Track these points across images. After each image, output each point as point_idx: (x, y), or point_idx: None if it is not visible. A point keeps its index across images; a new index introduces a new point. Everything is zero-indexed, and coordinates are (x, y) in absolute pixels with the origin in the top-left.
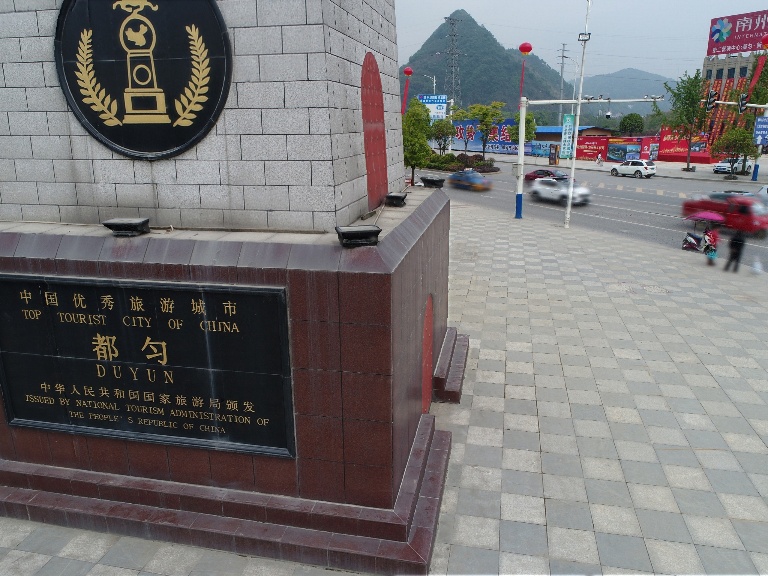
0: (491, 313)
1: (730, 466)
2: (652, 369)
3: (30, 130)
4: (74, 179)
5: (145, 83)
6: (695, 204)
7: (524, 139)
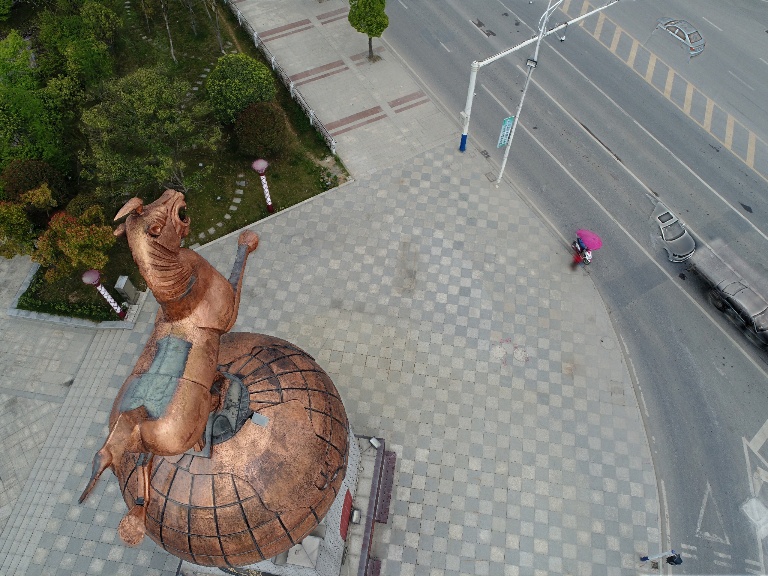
0: (413, 404)
1: (485, 573)
2: (482, 483)
3: (209, 569)
4: (230, 575)
5: (258, 575)
6: (631, 96)
7: (473, 94)
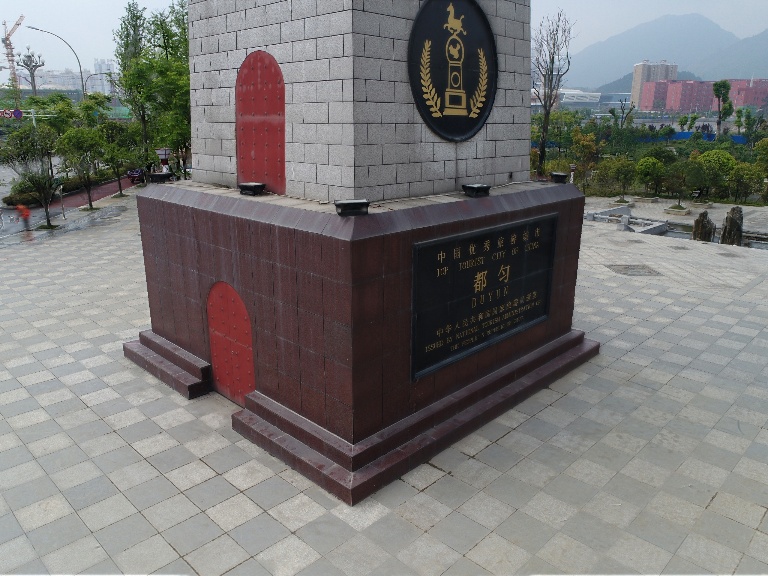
0: None
1: None
2: None
3: None
4: None
5: None
6: None
7: None
